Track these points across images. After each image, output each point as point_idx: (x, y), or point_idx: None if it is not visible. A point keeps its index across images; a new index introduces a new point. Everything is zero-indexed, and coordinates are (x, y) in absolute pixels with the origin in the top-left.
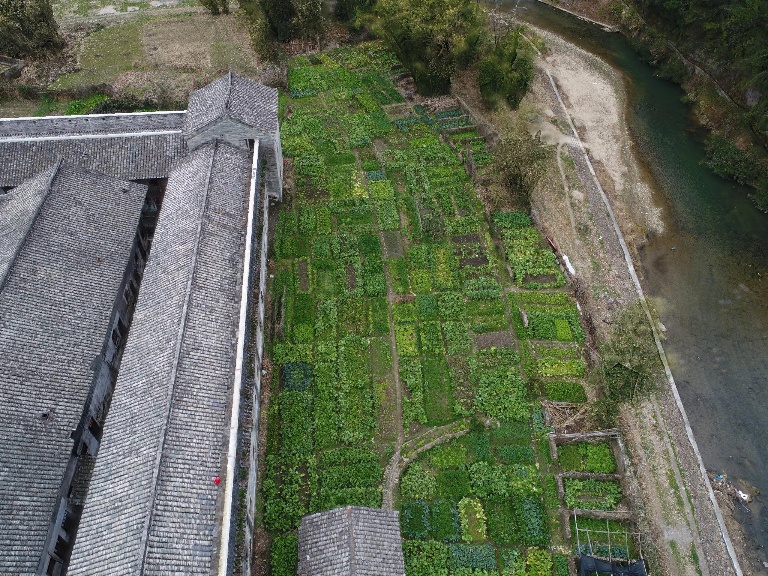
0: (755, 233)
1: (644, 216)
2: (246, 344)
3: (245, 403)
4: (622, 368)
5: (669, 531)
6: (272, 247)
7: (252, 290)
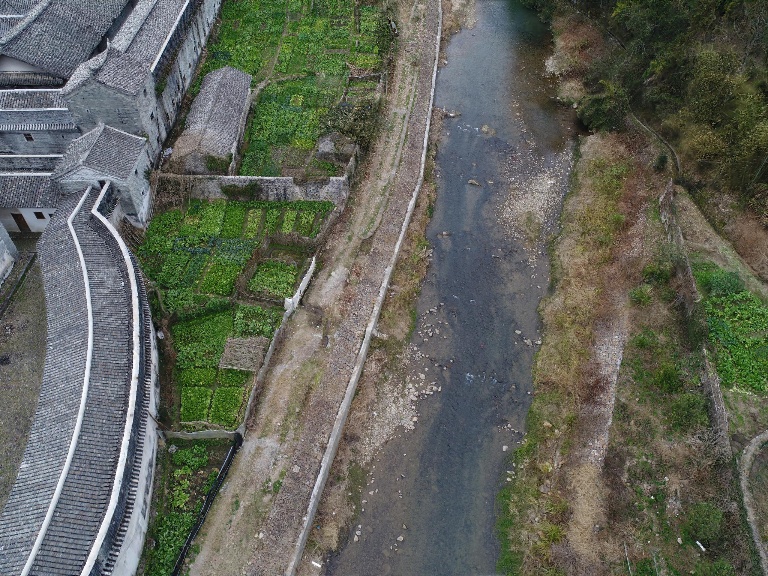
0: (532, 32)
1: (464, 22)
2: (189, 12)
3: (184, 30)
4: None
5: (395, 109)
6: (221, 12)
7: (198, 1)
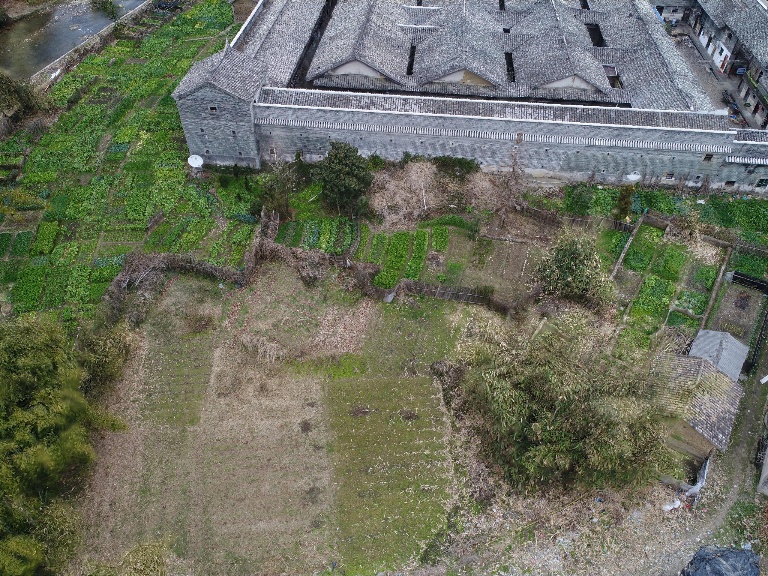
0: None
1: None
2: None
3: None
4: (107, 3)
5: None
6: None
7: None
